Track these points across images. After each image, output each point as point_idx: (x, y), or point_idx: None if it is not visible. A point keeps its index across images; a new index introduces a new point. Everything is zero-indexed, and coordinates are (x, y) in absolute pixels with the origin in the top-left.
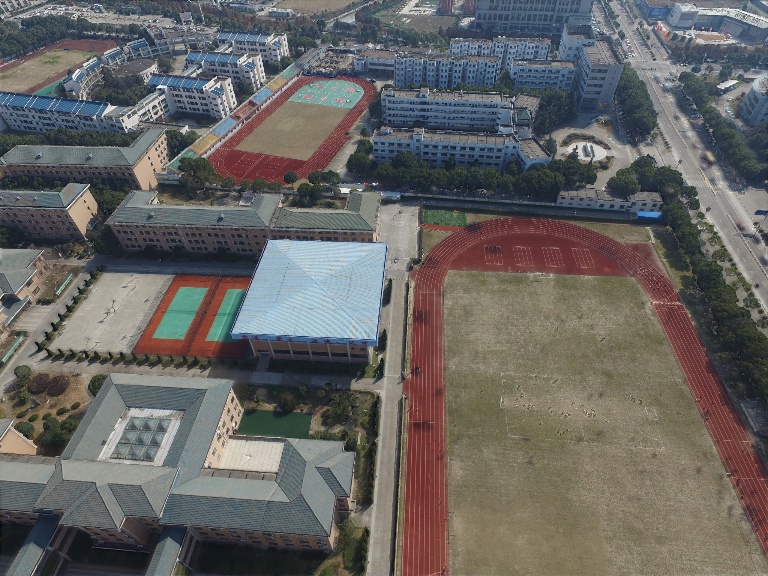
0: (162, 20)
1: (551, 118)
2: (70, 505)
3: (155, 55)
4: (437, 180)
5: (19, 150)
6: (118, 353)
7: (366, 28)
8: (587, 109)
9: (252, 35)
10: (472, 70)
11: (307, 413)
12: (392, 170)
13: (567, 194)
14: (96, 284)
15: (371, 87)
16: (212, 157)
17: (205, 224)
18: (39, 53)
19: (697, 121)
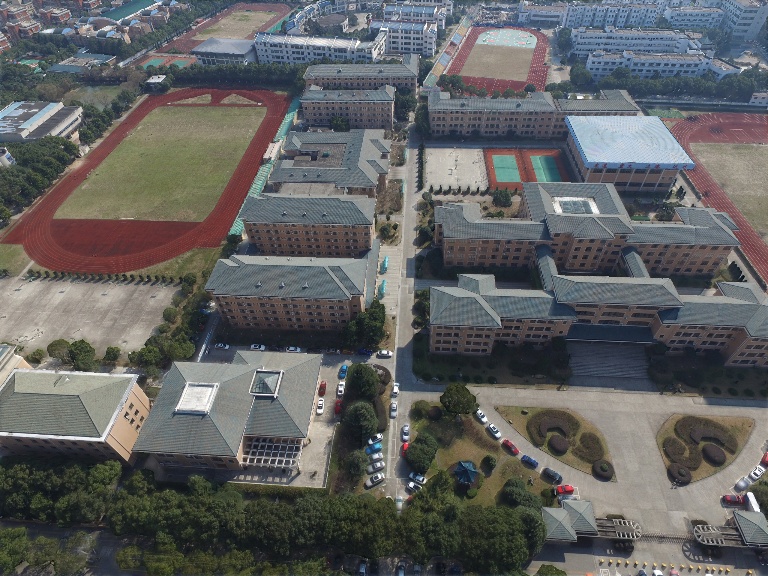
0: None
1: None
2: (575, 229)
3: None
4: (654, 86)
5: (322, 67)
6: (480, 190)
7: None
8: (733, 46)
9: None
10: (635, 15)
11: (644, 216)
12: (616, 80)
13: (759, 94)
14: (426, 155)
15: (540, 33)
16: None
17: (507, 109)
18: (226, 13)
19: None
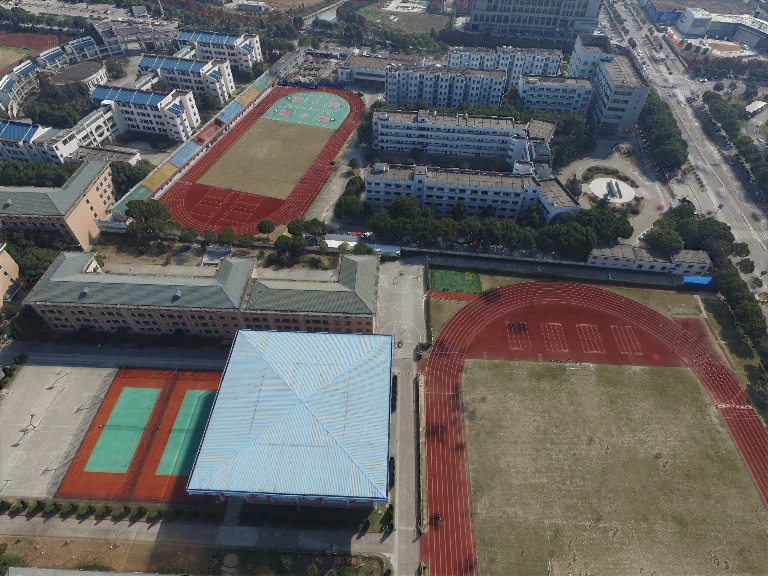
0: (114, 11)
1: (569, 148)
2: None
3: (104, 55)
4: (445, 234)
5: None
6: (35, 498)
7: (350, 28)
8: (605, 134)
9: (218, 36)
10: (476, 87)
11: None
12: (390, 220)
13: (600, 253)
14: (12, 384)
15: (358, 102)
16: (169, 194)
17: (156, 304)
18: None
19: (728, 152)
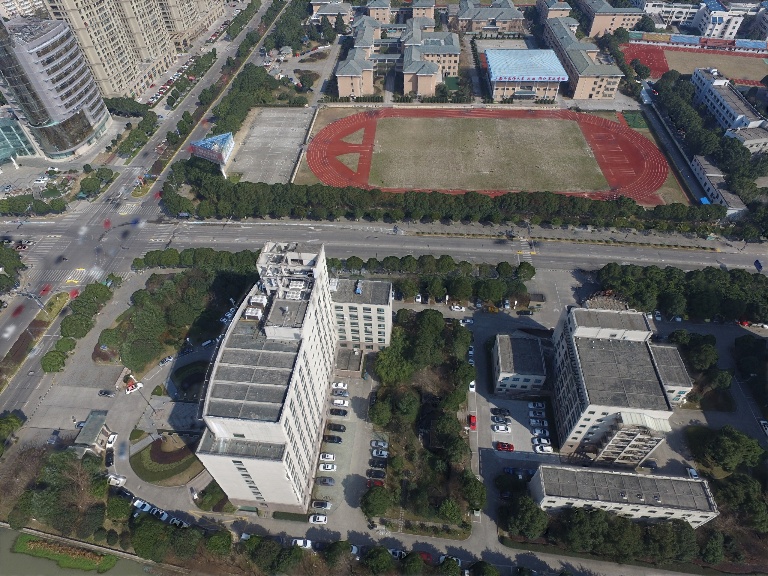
0: None
1: None
2: None
3: None
4: (668, 102)
5: None
6: (478, 51)
7: None
8: None
9: None
10: None
11: None
12: (665, 84)
13: (700, 159)
14: (515, 40)
15: None
16: (647, 45)
17: None
18: None
19: None
